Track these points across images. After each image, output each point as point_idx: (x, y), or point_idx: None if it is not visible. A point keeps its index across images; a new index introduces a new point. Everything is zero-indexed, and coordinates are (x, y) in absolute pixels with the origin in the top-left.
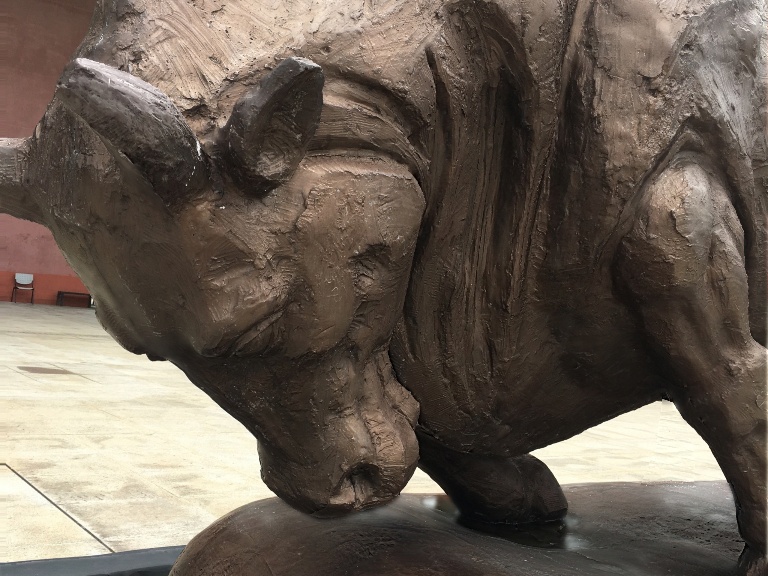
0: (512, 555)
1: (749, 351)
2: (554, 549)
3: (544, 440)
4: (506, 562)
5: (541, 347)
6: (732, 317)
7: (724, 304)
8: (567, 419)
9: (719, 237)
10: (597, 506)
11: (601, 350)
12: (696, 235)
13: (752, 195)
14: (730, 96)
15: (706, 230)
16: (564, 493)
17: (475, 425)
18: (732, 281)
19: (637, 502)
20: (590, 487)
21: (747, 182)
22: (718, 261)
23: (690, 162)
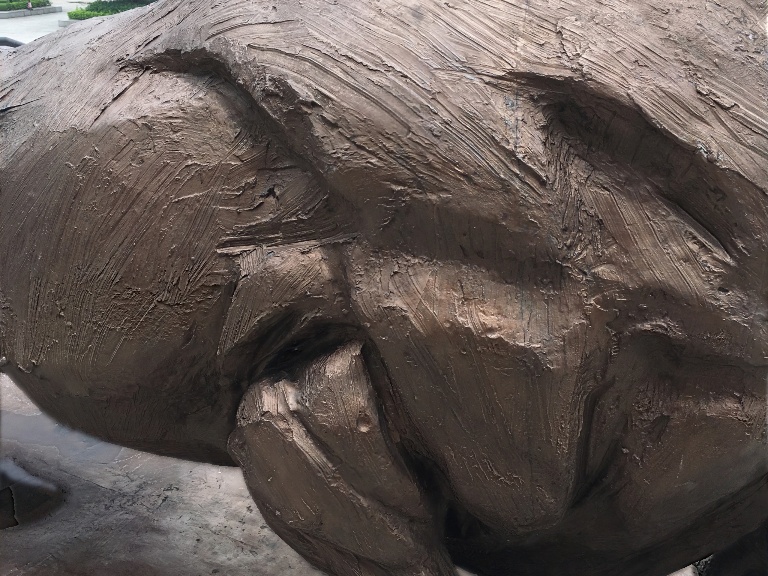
0: None
1: None
2: None
3: None
4: None
5: None
6: None
7: None
8: None
9: None
10: None
11: None
12: None
13: None
14: None
15: None
16: None
17: None
18: None
19: None
20: None
21: None
22: None
23: None
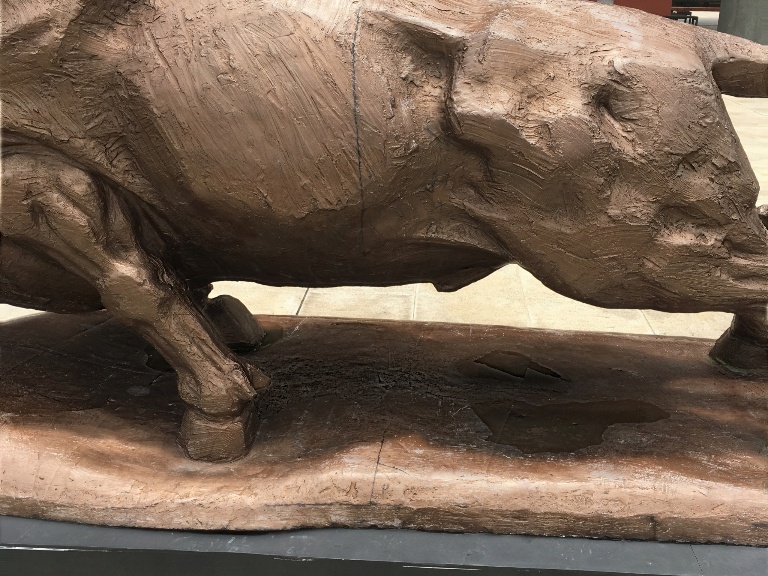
0: (44, 372)
1: (107, 273)
2: (157, 371)
3: (99, 305)
4: (8, 376)
5: (22, 257)
6: (79, 252)
7: (67, 244)
8: (98, 295)
9: (42, 202)
10: (299, 343)
11: (56, 261)
12: (1, 207)
13: (94, 164)
14: (34, 103)
15: (13, 202)
16: (314, 327)
17: (13, 297)
18: (62, 230)
19: (334, 345)
20: (348, 325)
21: (82, 157)
22: (48, 217)
23: (11, 154)
